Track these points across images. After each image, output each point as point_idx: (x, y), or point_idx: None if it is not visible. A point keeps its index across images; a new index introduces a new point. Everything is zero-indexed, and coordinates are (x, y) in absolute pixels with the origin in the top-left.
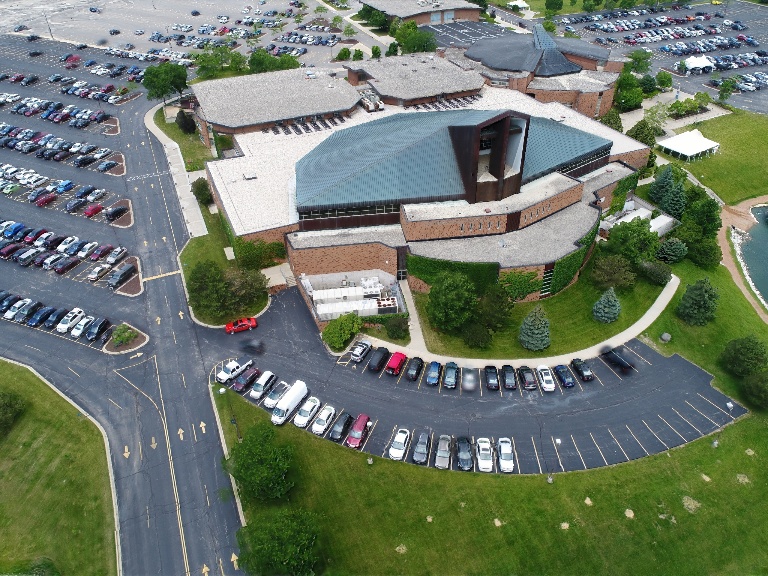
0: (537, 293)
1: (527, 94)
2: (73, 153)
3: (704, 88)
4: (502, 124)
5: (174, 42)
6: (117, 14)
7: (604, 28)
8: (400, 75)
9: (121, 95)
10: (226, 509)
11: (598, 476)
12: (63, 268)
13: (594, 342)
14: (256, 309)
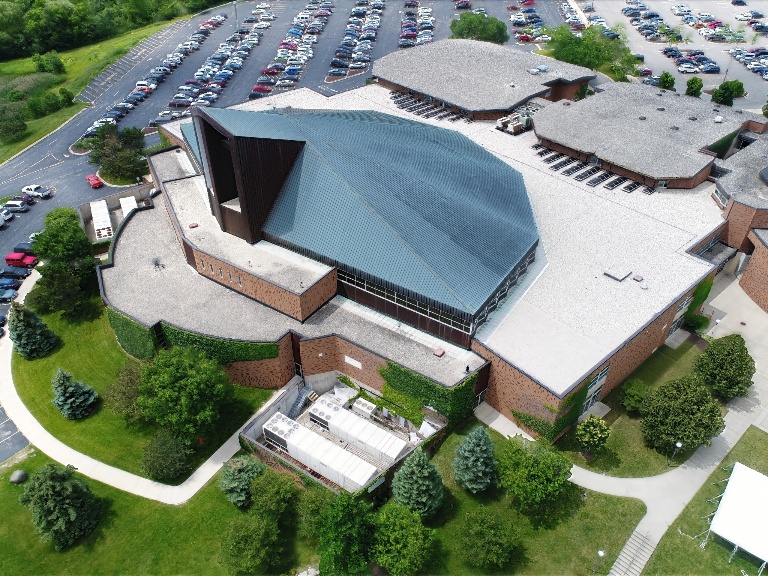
0: None
1: None
2: (352, 58)
3: None
4: None
5: None
6: None
7: None
8: (610, 113)
9: None
10: None
11: None
12: (172, 103)
13: (27, 400)
14: (118, 182)
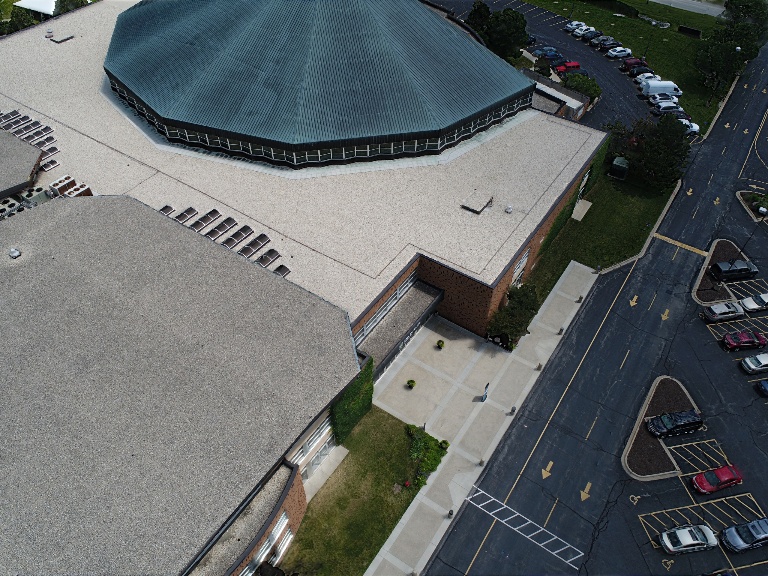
0: None
1: None
2: None
3: None
4: None
5: None
6: None
7: None
8: None
9: None
10: (738, 97)
11: (548, 8)
12: None
13: None
14: None
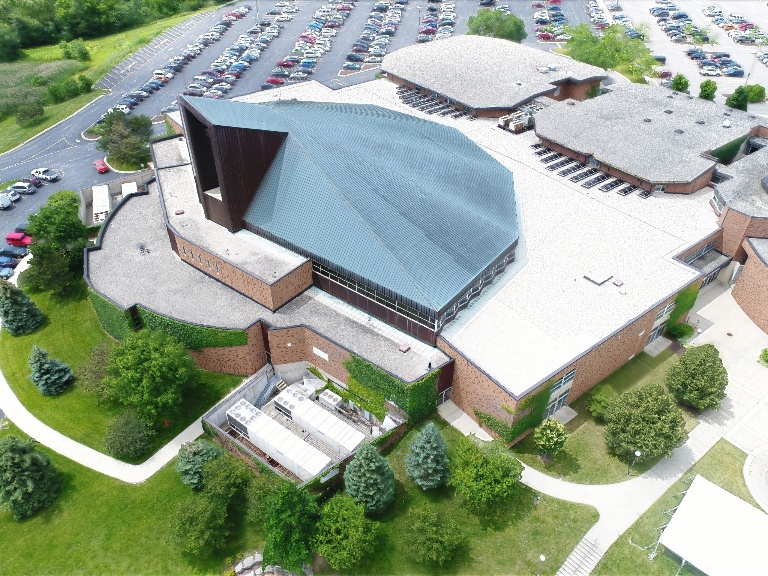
0: None
1: None
2: None
3: None
4: None
5: None
6: None
7: None
8: (614, 114)
9: None
10: None
11: None
12: (185, 92)
13: (8, 374)
14: (124, 168)
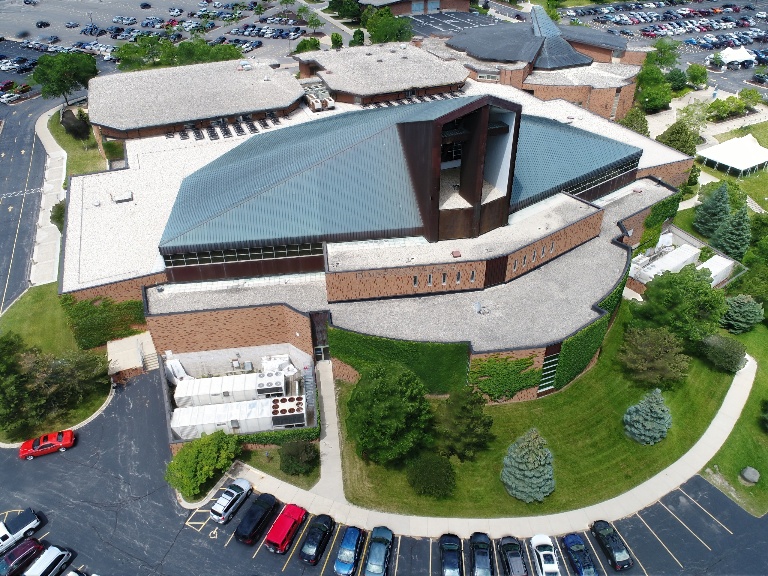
0: (533, 389)
1: (523, 90)
2: None
3: (747, 85)
4: (476, 118)
5: (109, 35)
6: (53, 6)
7: (616, 20)
8: (360, 66)
9: (21, 93)
10: None
11: None
12: None
13: (629, 483)
14: (83, 412)
